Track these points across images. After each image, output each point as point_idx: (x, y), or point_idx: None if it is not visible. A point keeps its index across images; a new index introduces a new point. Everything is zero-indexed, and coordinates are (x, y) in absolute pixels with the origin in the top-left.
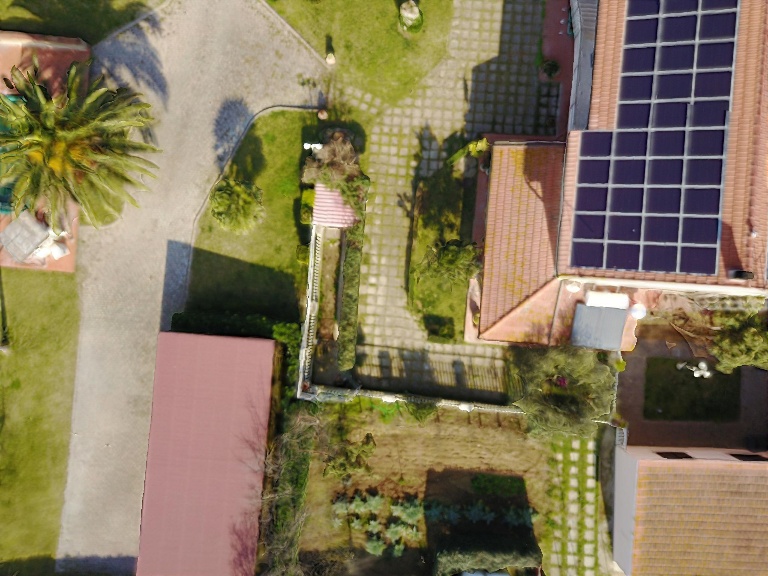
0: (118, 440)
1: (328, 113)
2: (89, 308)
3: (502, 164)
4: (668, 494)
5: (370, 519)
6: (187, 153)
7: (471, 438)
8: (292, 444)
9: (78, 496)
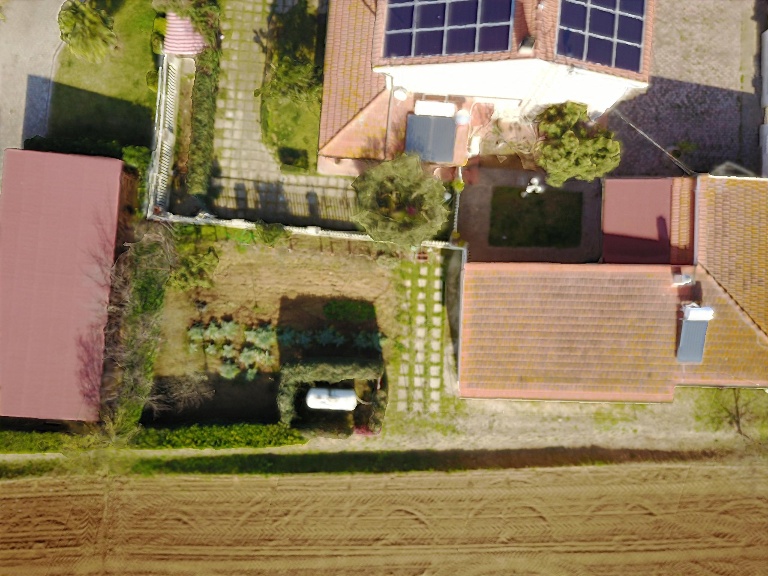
0: None
1: None
2: None
3: None
4: (493, 297)
5: (224, 344)
6: None
7: (323, 266)
8: (139, 261)
9: None
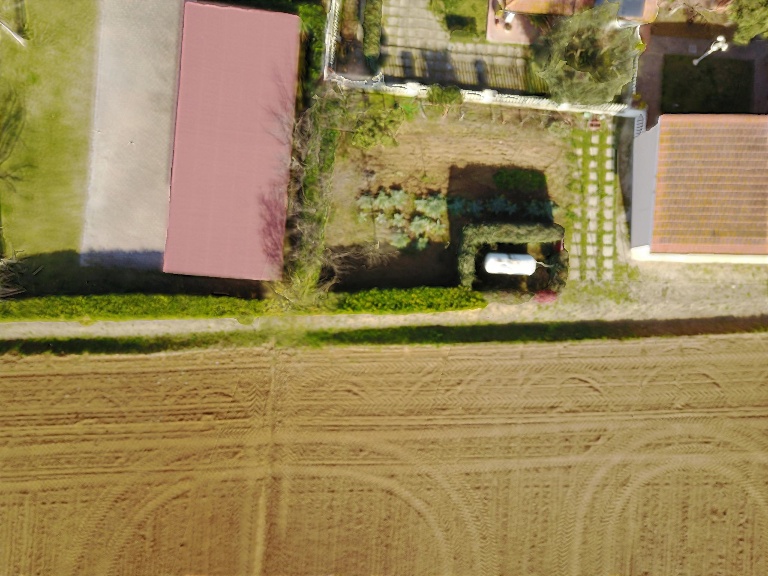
0: (142, 138)
1: None
2: (110, 7)
3: None
4: (689, 149)
5: (394, 213)
6: None
7: (493, 135)
8: (320, 120)
9: (102, 193)
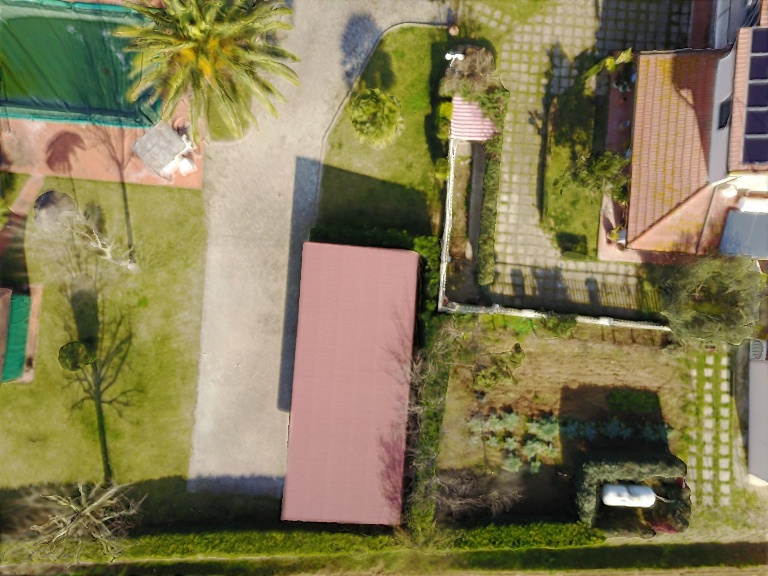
0: (248, 360)
1: (458, 30)
2: (216, 226)
3: (649, 73)
4: None
5: (505, 436)
6: (315, 69)
7: (605, 355)
8: (437, 356)
9: (208, 417)
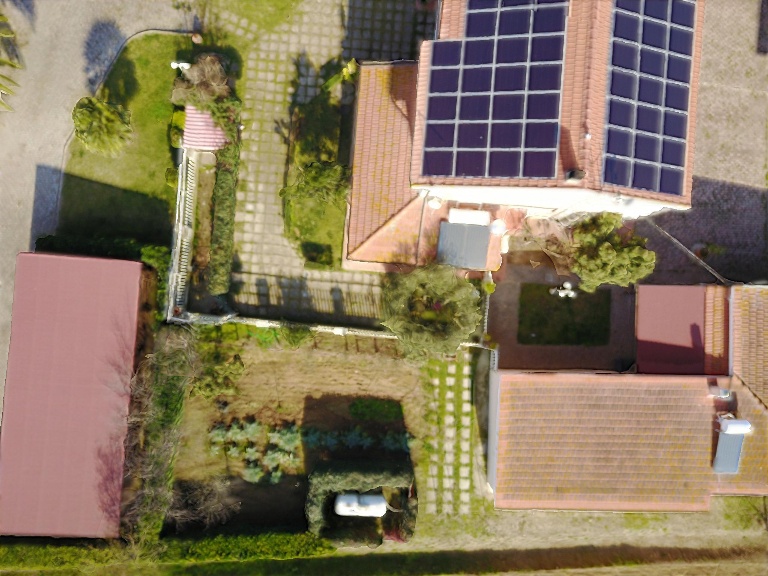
0: None
1: (204, 38)
2: None
3: (370, 84)
4: (529, 408)
5: (246, 447)
6: (57, 77)
7: (348, 365)
8: (160, 368)
9: None
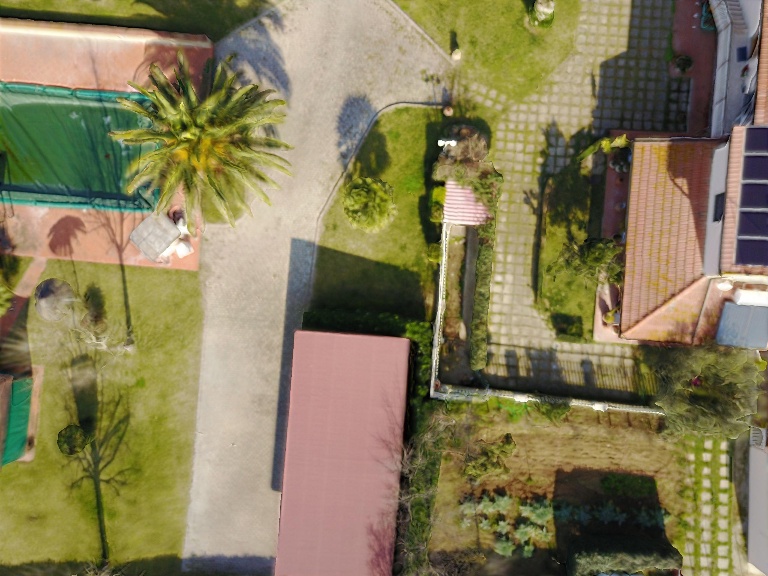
0: (243, 439)
1: (452, 110)
2: (212, 307)
3: (644, 161)
4: None
5: (499, 520)
6: (310, 150)
7: (600, 438)
8: (428, 444)
9: (204, 496)
